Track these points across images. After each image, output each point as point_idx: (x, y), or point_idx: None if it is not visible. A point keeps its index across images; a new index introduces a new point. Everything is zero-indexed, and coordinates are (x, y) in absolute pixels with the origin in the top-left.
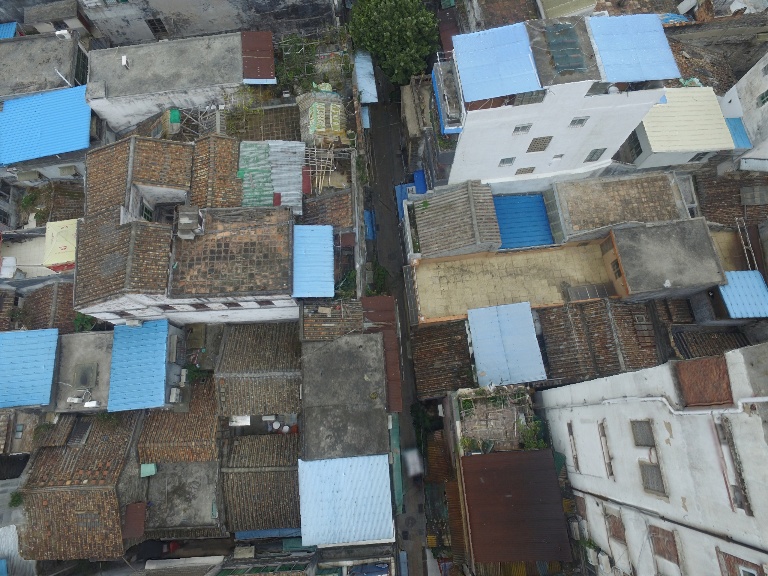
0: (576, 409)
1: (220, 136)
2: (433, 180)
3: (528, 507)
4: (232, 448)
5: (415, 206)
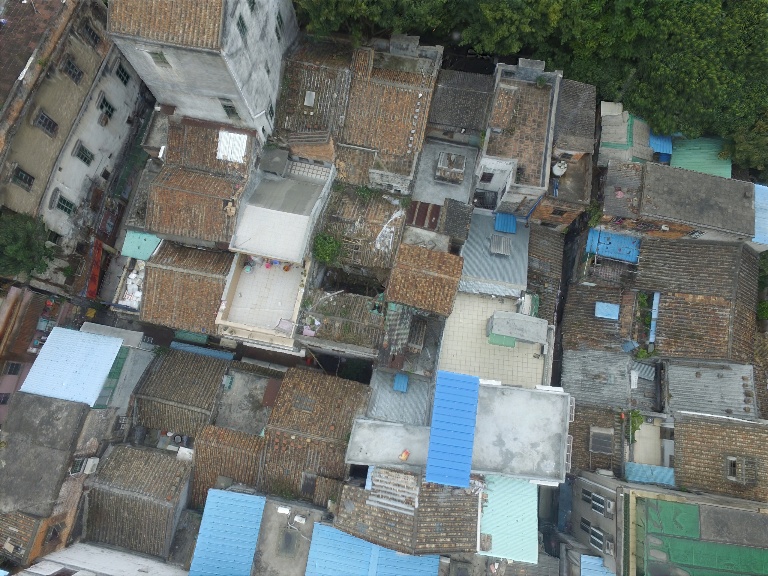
0: None
1: None
2: None
3: None
4: None
5: None
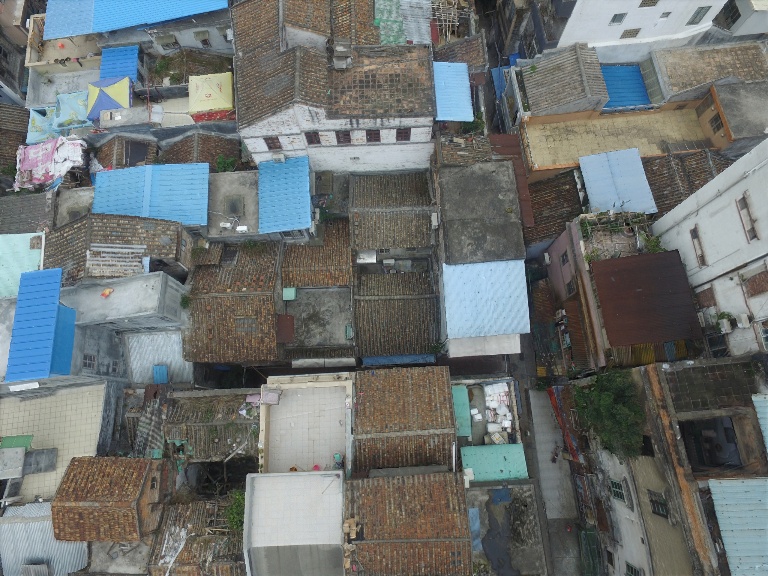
0: (704, 209)
1: None
2: (543, 43)
3: (658, 297)
4: (360, 282)
5: (523, 71)
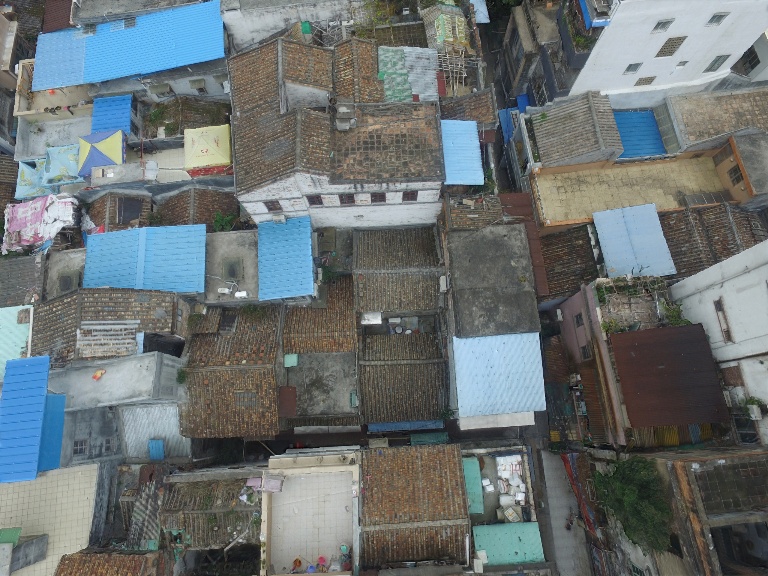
0: (730, 282)
1: (361, 39)
2: (554, 91)
3: (682, 376)
4: (365, 344)
5: (533, 119)
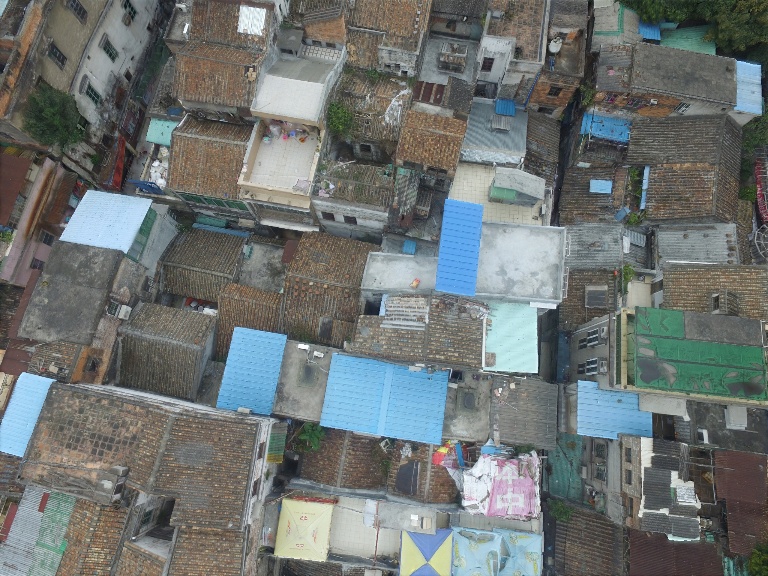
0: None
1: None
2: None
3: None
4: None
5: None
